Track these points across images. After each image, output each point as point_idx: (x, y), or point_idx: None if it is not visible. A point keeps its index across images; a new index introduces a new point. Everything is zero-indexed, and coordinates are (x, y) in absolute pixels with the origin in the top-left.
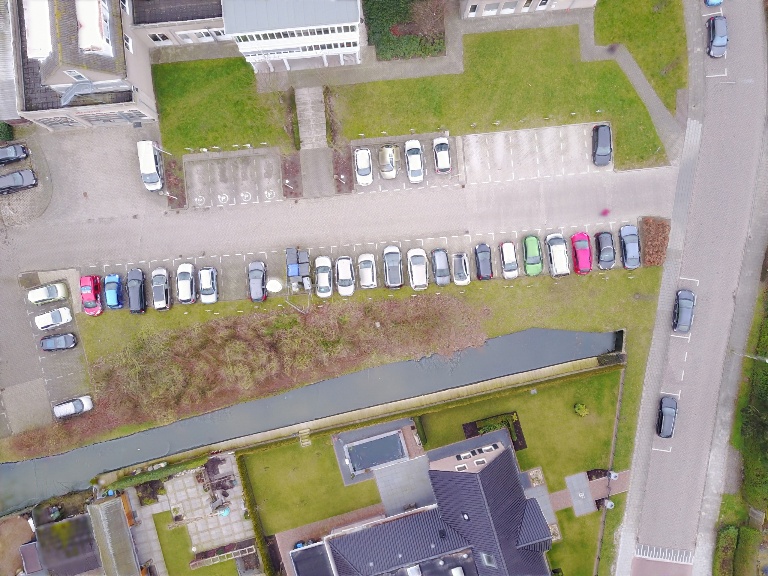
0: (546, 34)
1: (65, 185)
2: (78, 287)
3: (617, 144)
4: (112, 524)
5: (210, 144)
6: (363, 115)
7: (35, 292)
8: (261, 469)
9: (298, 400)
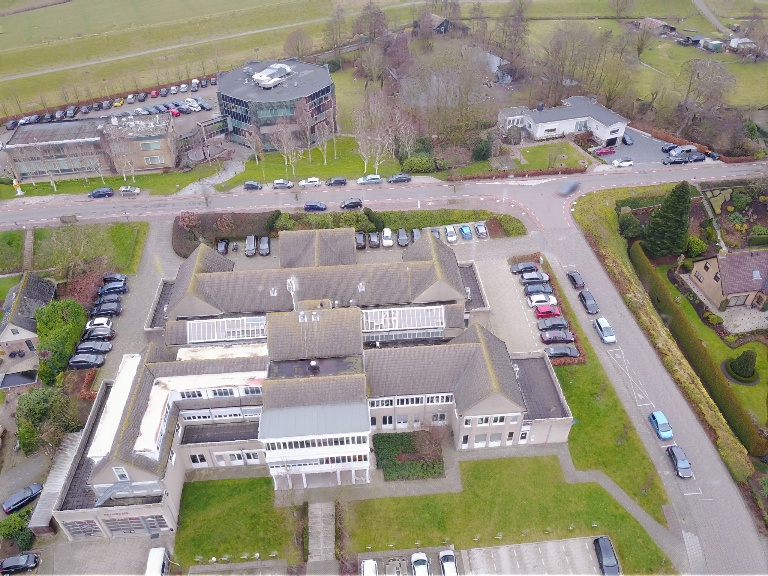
0: (531, 462)
1: None
2: None
3: (622, 557)
4: None
5: (220, 555)
6: (371, 528)
7: None
8: None
9: None
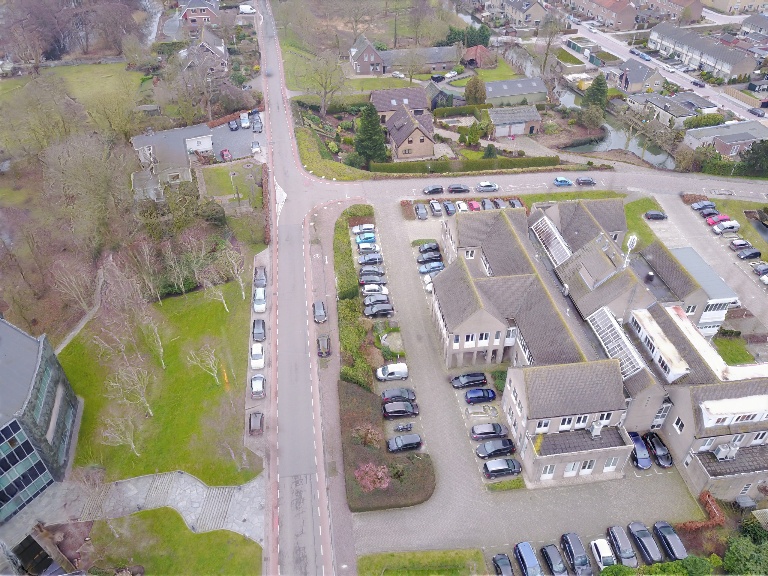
0: None
1: None
2: None
3: None
4: None
5: None
6: None
7: None
8: None
9: None
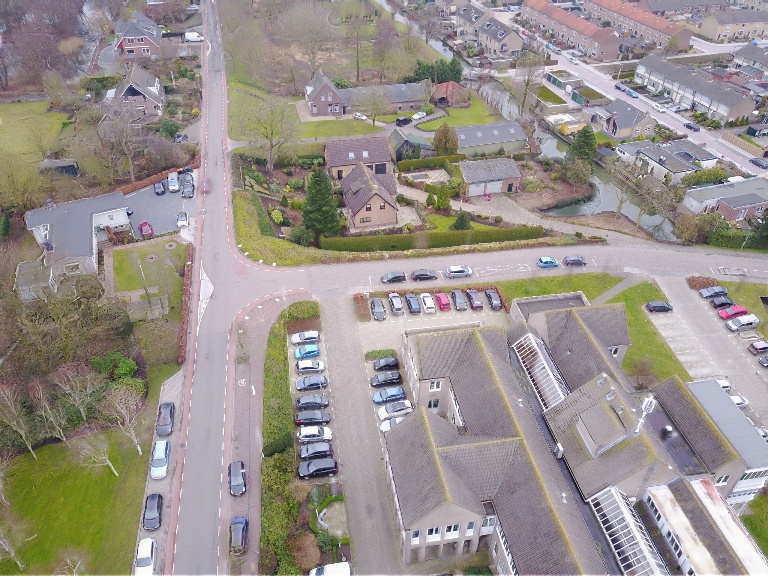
0: None
1: None
2: None
3: None
4: None
5: None
6: None
7: None
8: None
9: None
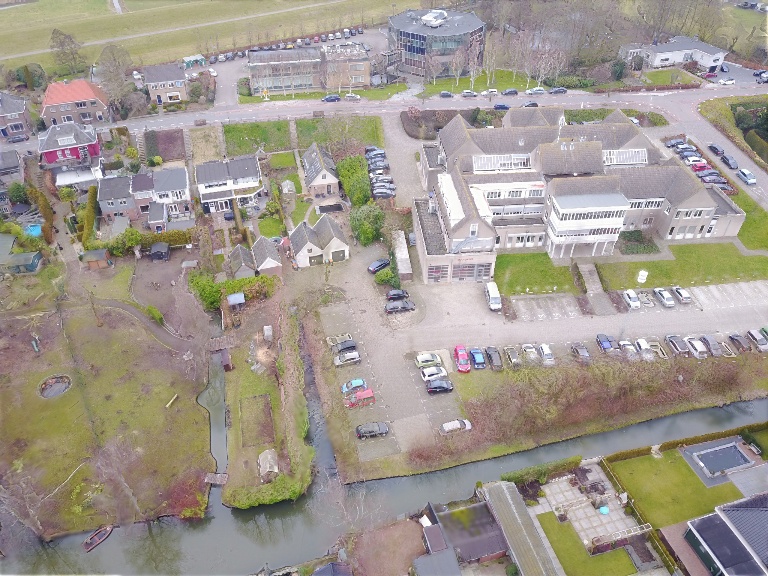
0: (716, 245)
1: (435, 309)
2: (449, 358)
3: None
4: (514, 499)
5: None
6: (622, 278)
7: (422, 356)
8: (626, 475)
9: (635, 434)
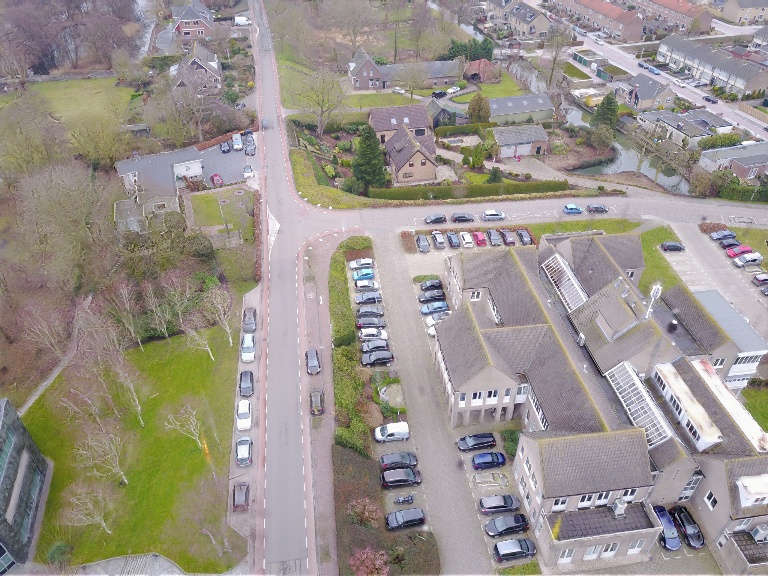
0: None
1: None
2: None
3: None
4: None
5: None
6: None
7: None
8: None
9: None
